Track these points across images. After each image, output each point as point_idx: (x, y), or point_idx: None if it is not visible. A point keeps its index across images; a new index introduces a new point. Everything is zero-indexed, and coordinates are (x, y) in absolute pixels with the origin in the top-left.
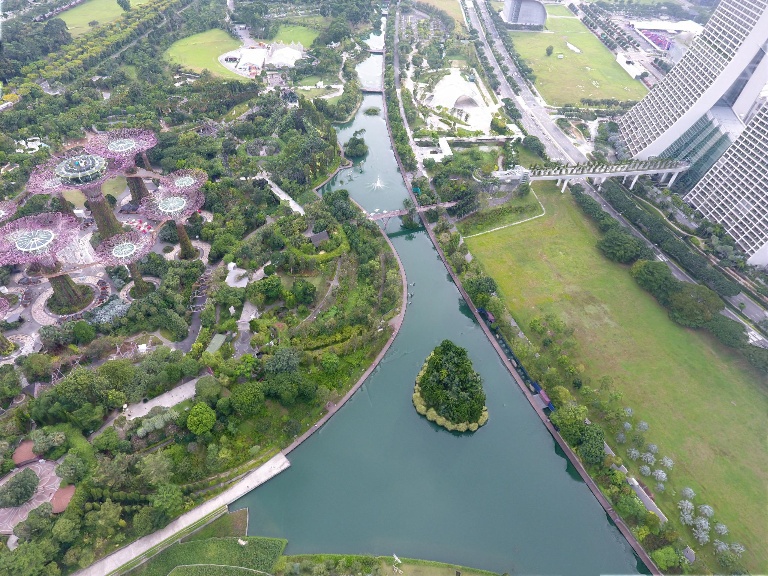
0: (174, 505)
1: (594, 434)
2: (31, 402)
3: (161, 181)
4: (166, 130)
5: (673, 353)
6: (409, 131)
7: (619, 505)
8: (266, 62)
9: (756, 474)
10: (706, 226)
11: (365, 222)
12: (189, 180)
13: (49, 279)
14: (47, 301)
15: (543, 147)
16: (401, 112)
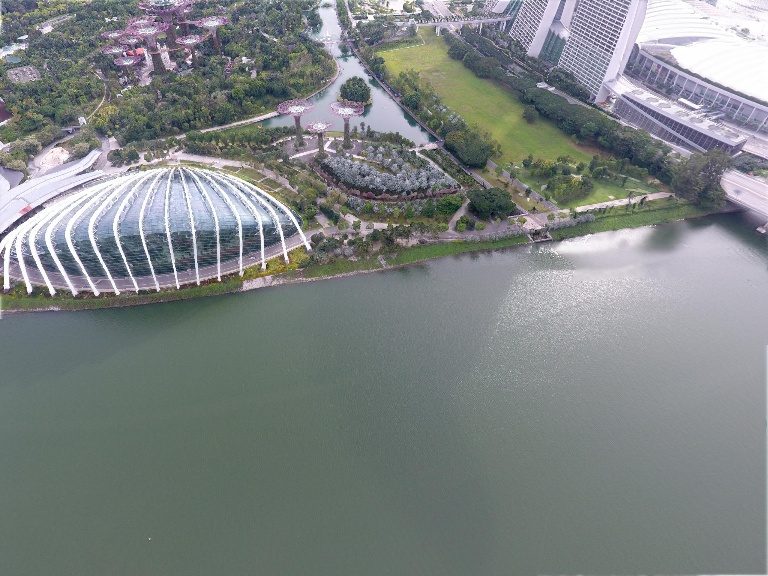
0: (231, 110)
1: (414, 95)
2: None
3: None
4: None
5: (471, 85)
6: (350, 13)
7: (421, 115)
8: None
9: (488, 112)
10: (510, 41)
11: (317, 43)
12: None
13: (153, 56)
14: (149, 74)
15: (431, 15)
16: (346, 5)
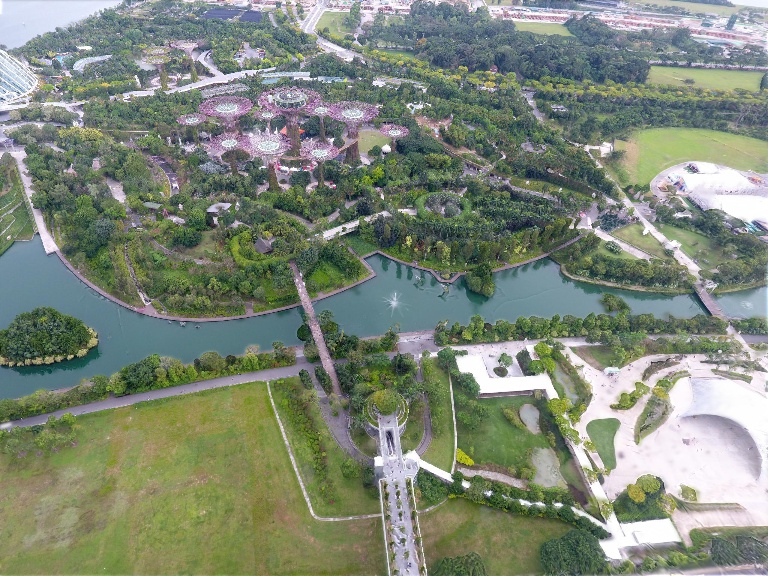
0: (33, 202)
1: None
2: (129, 150)
3: (319, 143)
4: (467, 152)
5: None
6: (568, 345)
7: None
8: (694, 189)
9: None
10: None
11: None
12: (321, 154)
13: None
14: None
15: (551, 568)
16: None
